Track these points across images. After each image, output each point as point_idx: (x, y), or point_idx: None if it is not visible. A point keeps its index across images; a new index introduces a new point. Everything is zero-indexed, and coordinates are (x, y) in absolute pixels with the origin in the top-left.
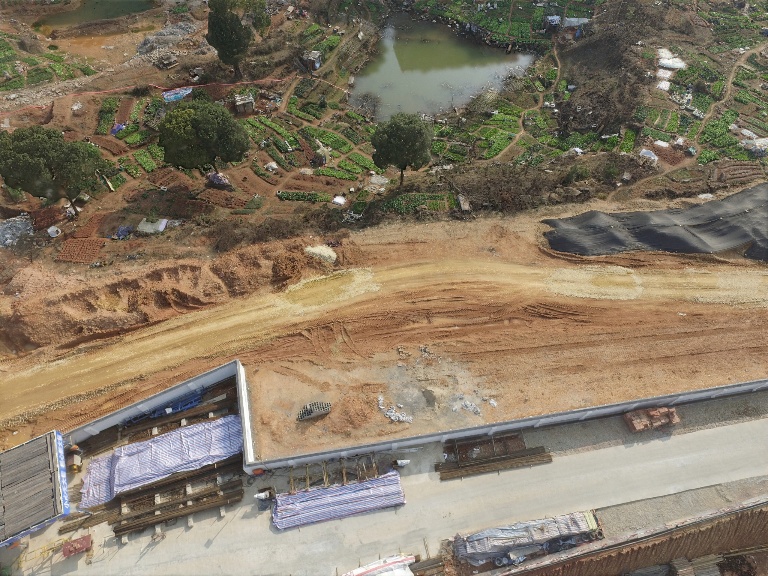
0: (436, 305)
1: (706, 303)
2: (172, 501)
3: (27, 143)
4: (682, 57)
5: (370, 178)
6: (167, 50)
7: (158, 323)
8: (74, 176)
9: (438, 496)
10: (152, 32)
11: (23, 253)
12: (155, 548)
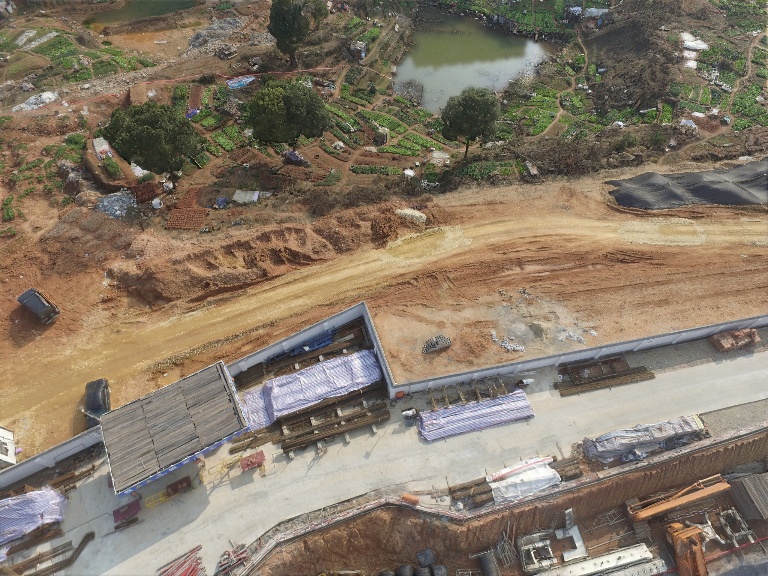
0: (525, 255)
1: (763, 246)
2: (327, 422)
3: (148, 116)
4: (704, 39)
5: (431, 154)
6: (221, 43)
7: (276, 278)
8: (185, 148)
9: (561, 409)
10: (201, 27)
11: (133, 223)
12: (320, 461)
